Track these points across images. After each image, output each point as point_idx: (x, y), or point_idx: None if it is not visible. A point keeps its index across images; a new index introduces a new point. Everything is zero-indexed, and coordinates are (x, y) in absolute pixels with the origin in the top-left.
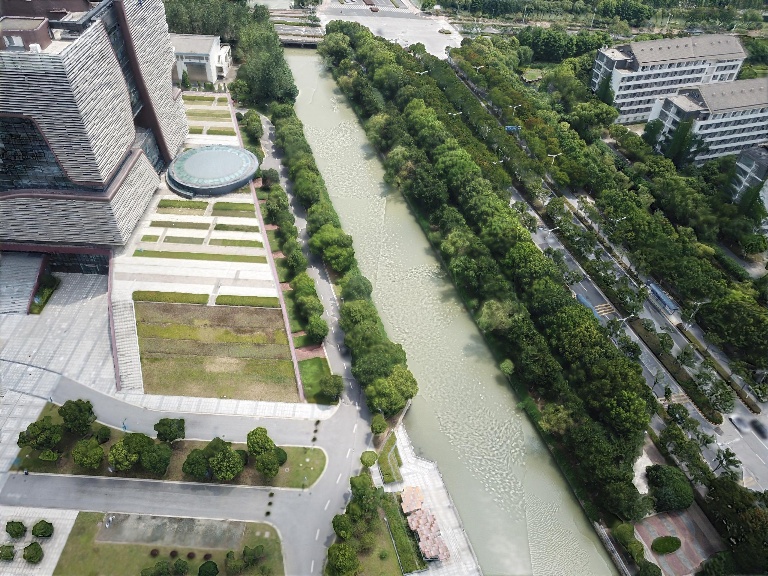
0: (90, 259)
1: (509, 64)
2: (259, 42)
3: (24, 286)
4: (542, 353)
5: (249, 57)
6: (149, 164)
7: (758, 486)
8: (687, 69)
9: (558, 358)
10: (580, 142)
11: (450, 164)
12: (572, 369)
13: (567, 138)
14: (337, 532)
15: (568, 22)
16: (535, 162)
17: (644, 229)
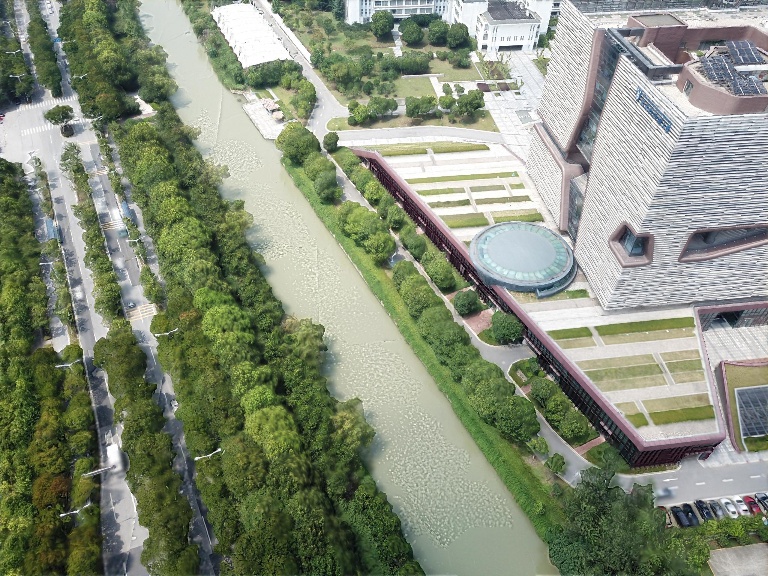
0: None
1: None
2: None
3: None
4: None
5: None
6: (560, 191)
7: (79, 141)
8: None
9: None
10: (5, 407)
11: None
12: None
13: None
14: None
15: None
16: None
17: None
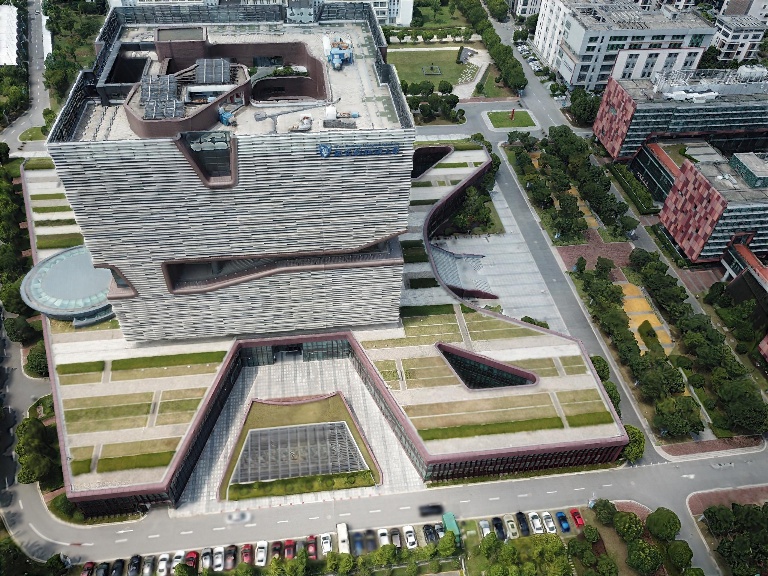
0: None
1: None
2: None
3: None
4: None
5: None
6: None
7: None
8: None
9: None
10: None
11: None
12: None
13: None
14: (16, 100)
15: None
16: None
17: None
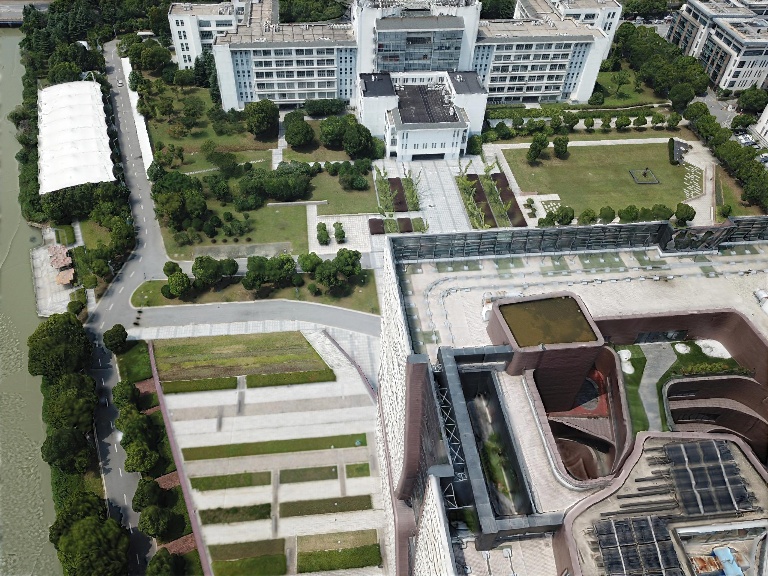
0: None
1: None
2: None
3: None
4: None
5: None
6: None
7: None
8: None
9: None
10: None
11: None
12: None
13: None
14: None
15: None
16: None
17: None
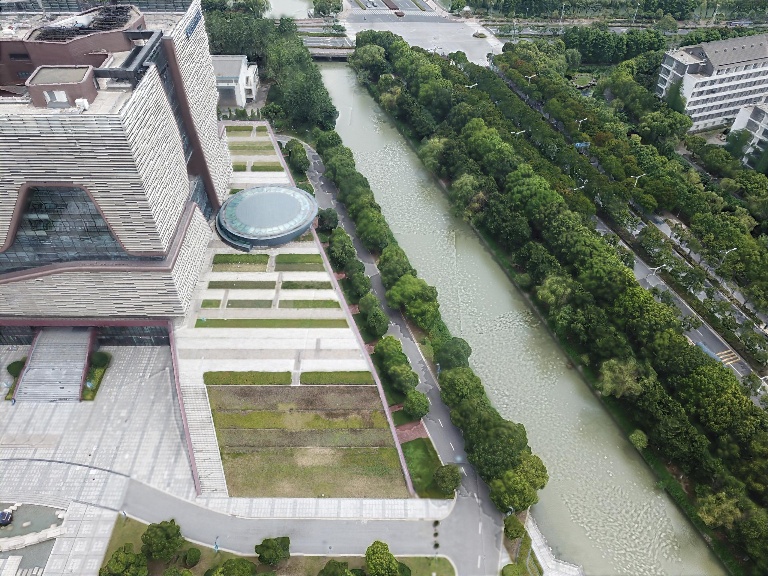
0: (144, 331)
1: (559, 70)
2: (292, 61)
3: (72, 367)
4: (683, 424)
5: (281, 77)
6: (202, 217)
7: None
8: (763, 70)
9: (699, 427)
10: (662, 159)
11: (528, 194)
12: (721, 443)
13: (646, 155)
14: None
15: (607, 18)
16: (618, 185)
17: (756, 260)
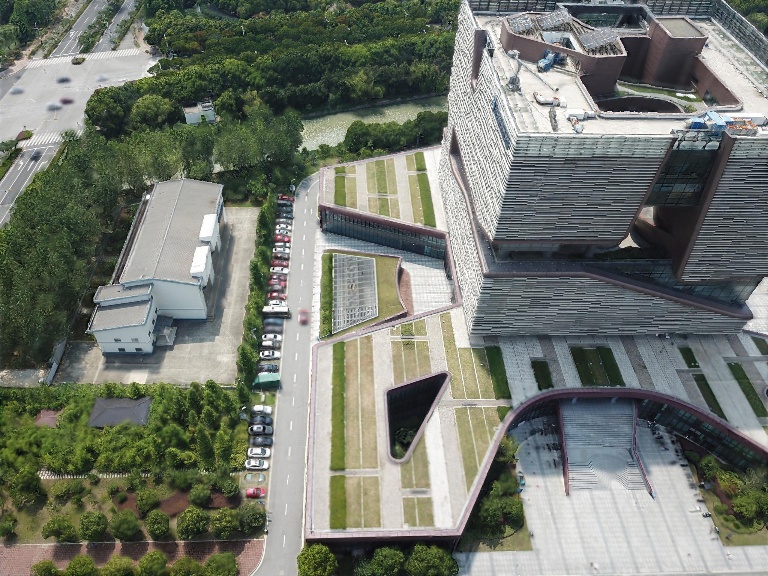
0: None
1: None
2: (208, 136)
3: None
4: None
5: None
6: None
7: None
8: None
9: None
10: (383, 4)
11: None
12: None
13: (376, 8)
14: None
15: None
16: None
17: None
